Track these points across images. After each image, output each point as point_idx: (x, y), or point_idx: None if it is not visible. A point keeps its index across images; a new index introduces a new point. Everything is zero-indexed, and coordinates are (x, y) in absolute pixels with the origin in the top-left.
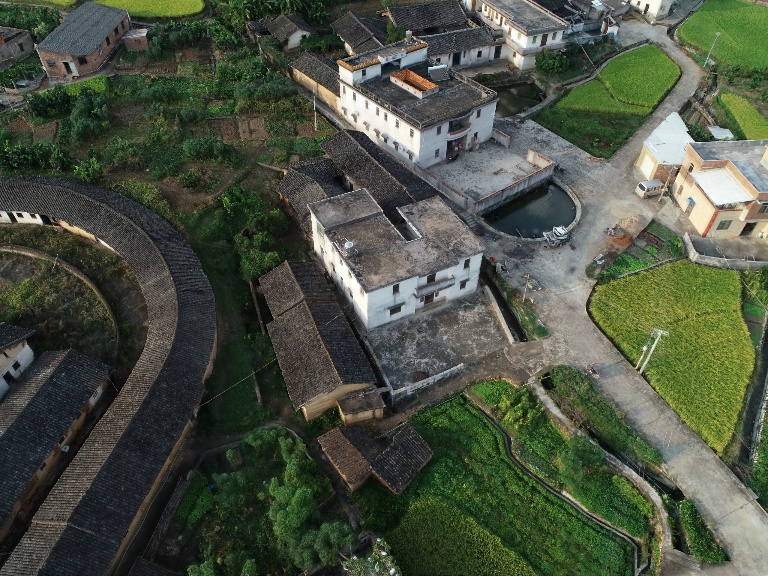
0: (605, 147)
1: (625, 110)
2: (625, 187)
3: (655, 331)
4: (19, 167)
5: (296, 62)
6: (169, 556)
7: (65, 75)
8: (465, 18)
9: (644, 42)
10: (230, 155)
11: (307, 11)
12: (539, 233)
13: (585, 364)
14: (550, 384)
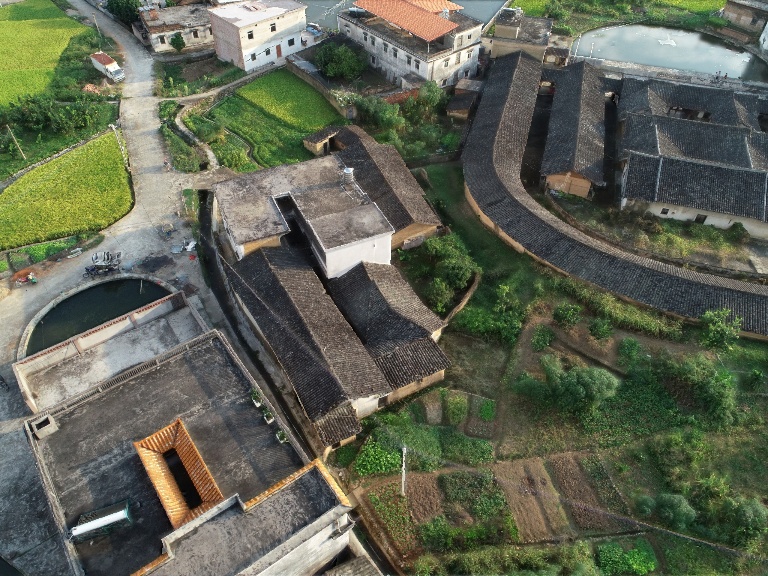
0: None
1: None
2: None
3: None
4: None
5: None
6: (457, 124)
7: None
8: None
9: None
10: None
11: None
12: None
13: None
14: None
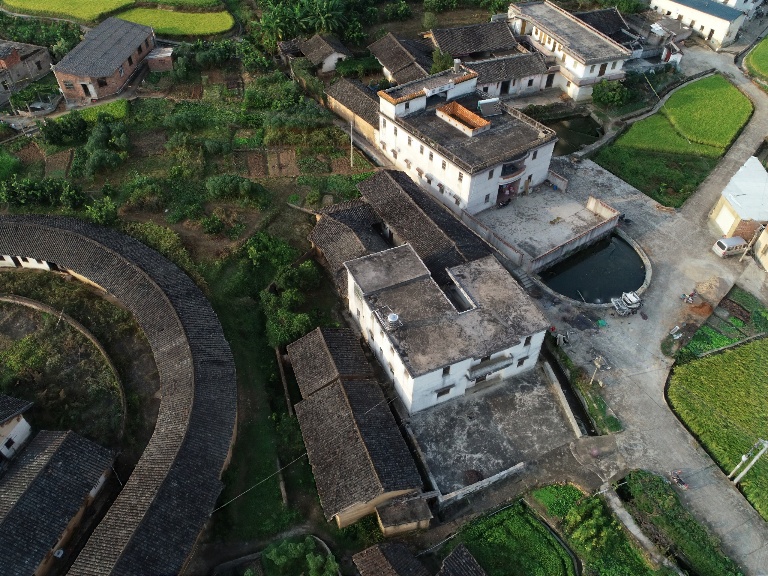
0: (674, 194)
1: (694, 150)
2: (700, 243)
3: (760, 442)
4: (27, 203)
5: (331, 89)
6: None
7: (83, 97)
8: (514, 42)
9: (709, 71)
10: (257, 195)
11: (343, 31)
12: (603, 296)
13: (668, 469)
14: (626, 492)
